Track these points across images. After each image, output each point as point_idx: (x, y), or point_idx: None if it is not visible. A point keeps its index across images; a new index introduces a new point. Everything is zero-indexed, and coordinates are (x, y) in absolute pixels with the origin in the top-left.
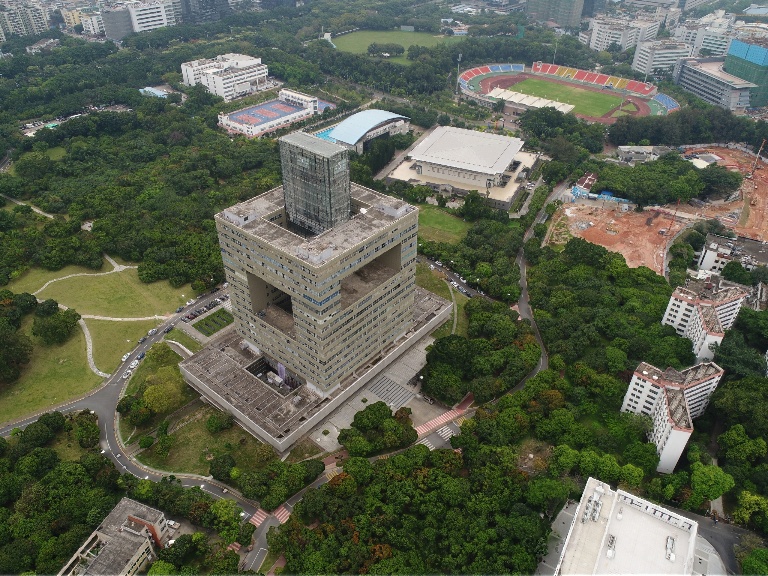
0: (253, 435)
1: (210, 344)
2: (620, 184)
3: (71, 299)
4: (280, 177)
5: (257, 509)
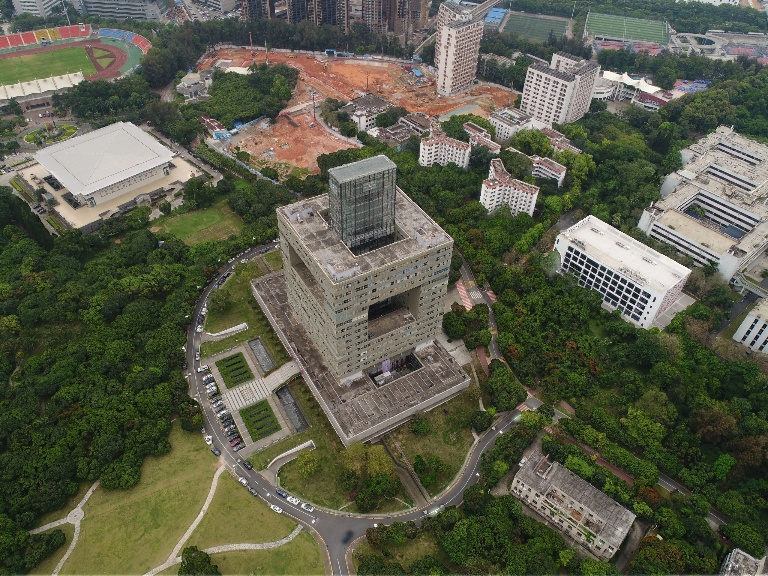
0: (439, 405)
1: (330, 410)
2: (239, 112)
3: (120, 575)
4: (2, 309)
5: (517, 409)
